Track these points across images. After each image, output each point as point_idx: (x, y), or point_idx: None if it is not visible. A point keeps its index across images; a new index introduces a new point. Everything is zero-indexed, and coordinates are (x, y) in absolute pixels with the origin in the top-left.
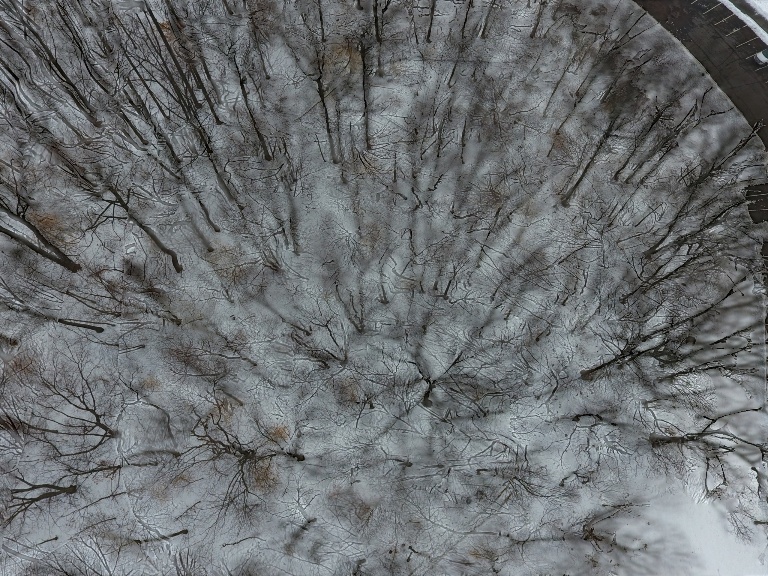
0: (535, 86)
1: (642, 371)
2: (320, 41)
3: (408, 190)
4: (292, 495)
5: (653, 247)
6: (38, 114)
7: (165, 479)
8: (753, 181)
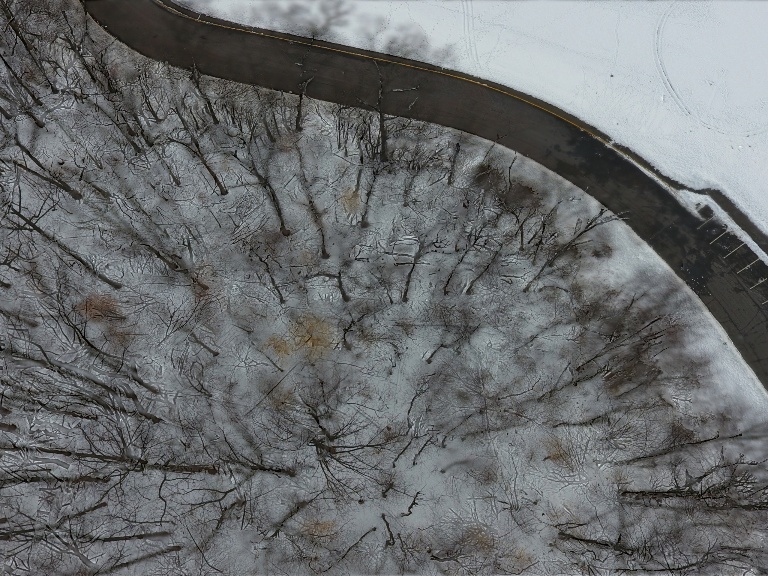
0: (529, 357)
1: None
2: (278, 303)
3: (377, 518)
4: None
5: None
6: None
7: None
8: None
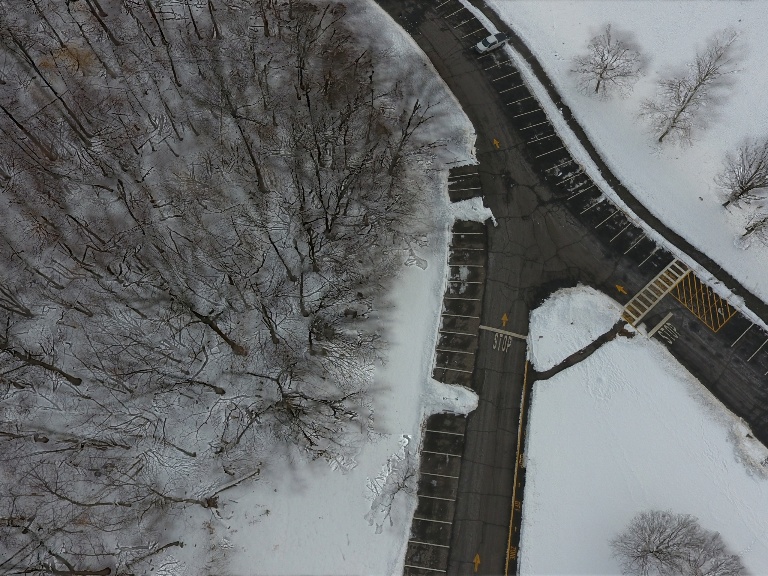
0: (264, 82)
1: (297, 344)
2: (59, 47)
3: (115, 183)
4: None
5: None
6: None
7: None
8: (458, 163)
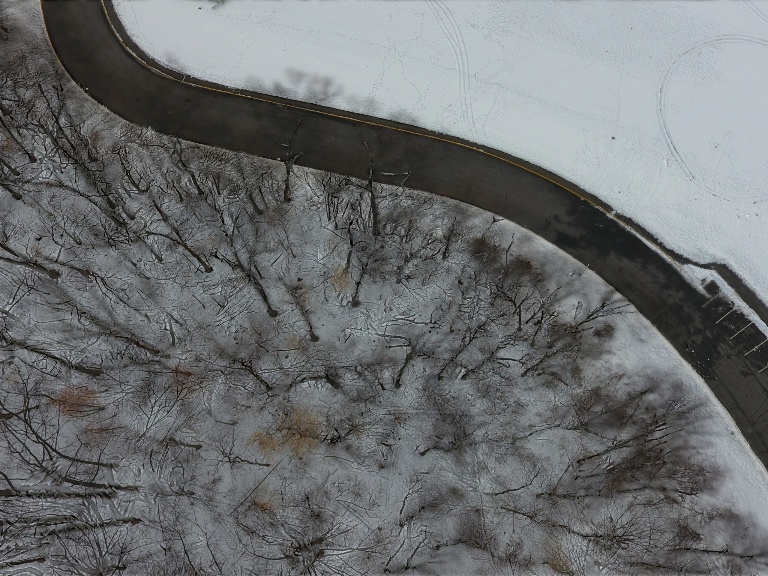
0: (527, 447)
1: None
2: (264, 390)
3: None
4: None
5: None
6: None
7: None
8: None
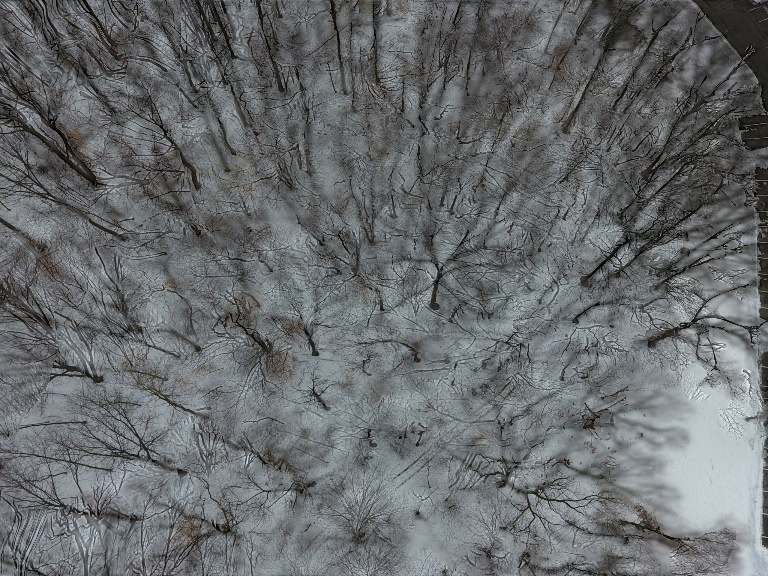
0: (537, 25)
1: (639, 279)
2: None
3: (415, 118)
4: (307, 384)
5: (650, 166)
6: (63, 43)
7: (187, 370)
8: (746, 112)
